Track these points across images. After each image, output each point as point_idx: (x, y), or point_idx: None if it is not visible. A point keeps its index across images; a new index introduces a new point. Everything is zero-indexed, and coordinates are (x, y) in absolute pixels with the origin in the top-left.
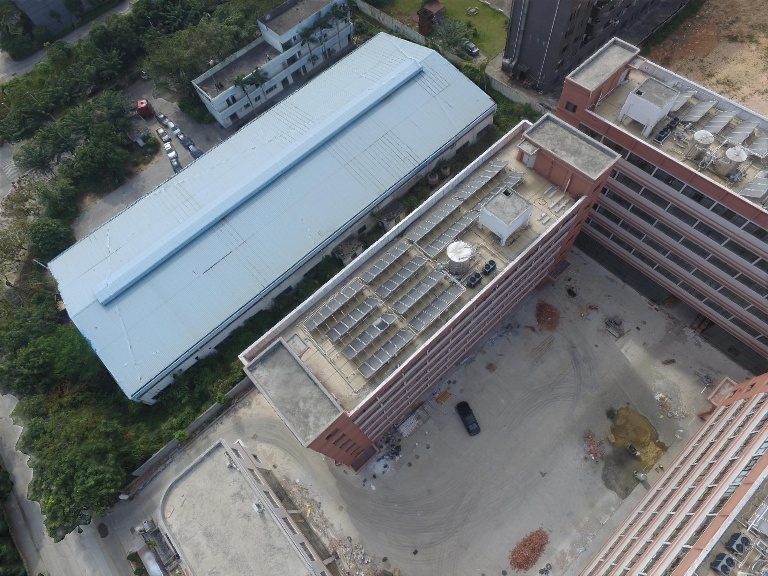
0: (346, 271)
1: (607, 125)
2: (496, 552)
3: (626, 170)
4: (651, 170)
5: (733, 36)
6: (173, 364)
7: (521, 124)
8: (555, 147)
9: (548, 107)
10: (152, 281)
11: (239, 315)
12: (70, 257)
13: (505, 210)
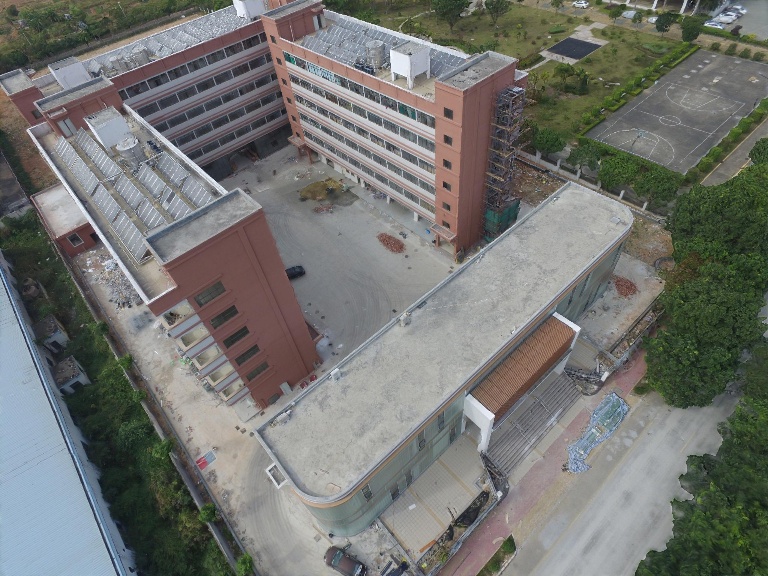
0: None
1: None
2: (393, 261)
3: None
4: (125, 96)
5: None
6: None
7: (29, 131)
8: None
9: (19, 206)
10: None
11: None
12: None
13: (106, 118)
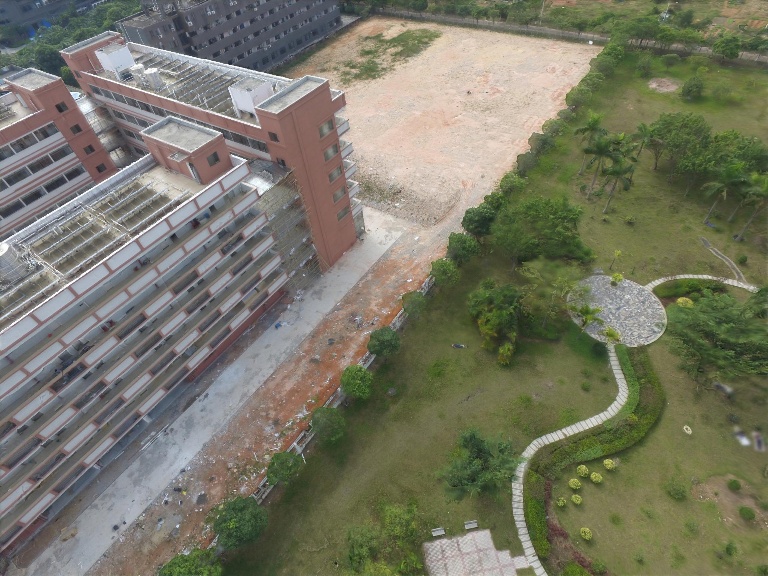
0: None
1: (91, 77)
2: None
3: (122, 109)
4: None
5: (324, 69)
6: None
7: None
8: (25, 83)
9: None
10: None
11: None
12: None
13: None
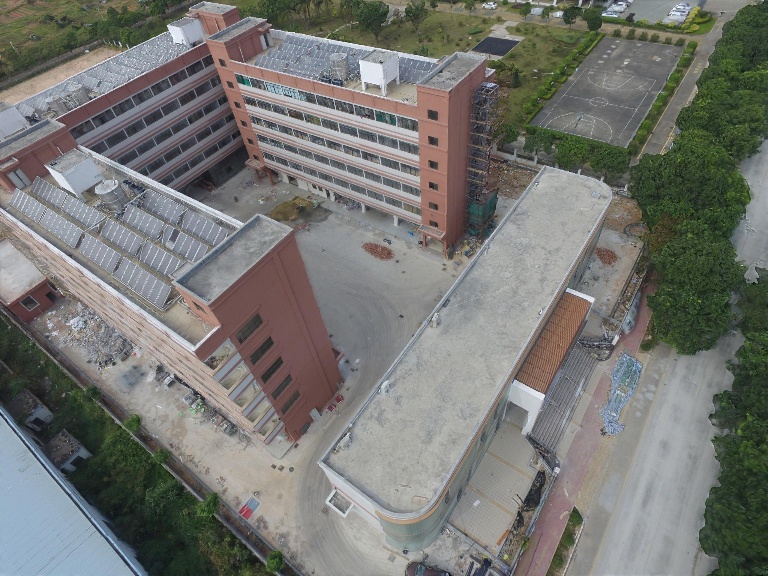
0: None
1: None
2: (385, 268)
3: None
4: None
5: None
6: None
7: None
8: None
9: None
10: None
11: None
12: None
13: (72, 162)
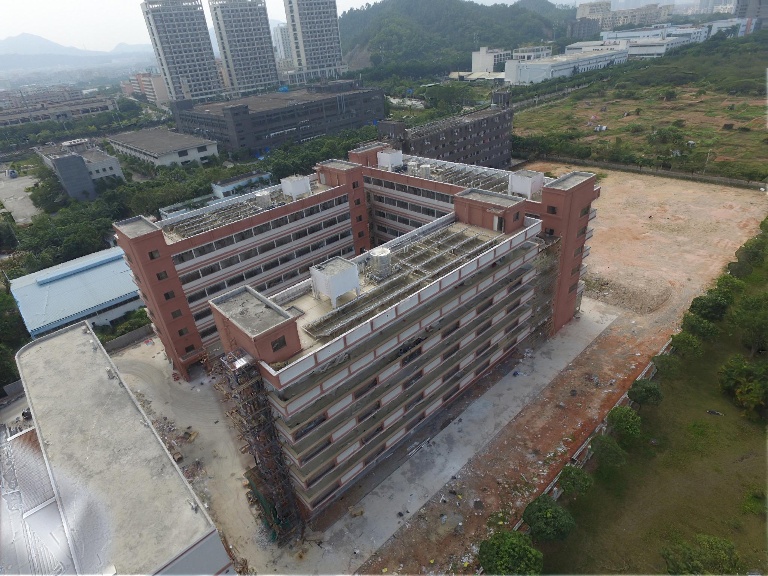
0: (198, 211)
1: (370, 169)
2: None
3: (386, 193)
4: (394, 187)
5: None
6: (73, 315)
7: None
8: None
9: None
10: (81, 275)
11: (136, 296)
12: (29, 275)
13: None
